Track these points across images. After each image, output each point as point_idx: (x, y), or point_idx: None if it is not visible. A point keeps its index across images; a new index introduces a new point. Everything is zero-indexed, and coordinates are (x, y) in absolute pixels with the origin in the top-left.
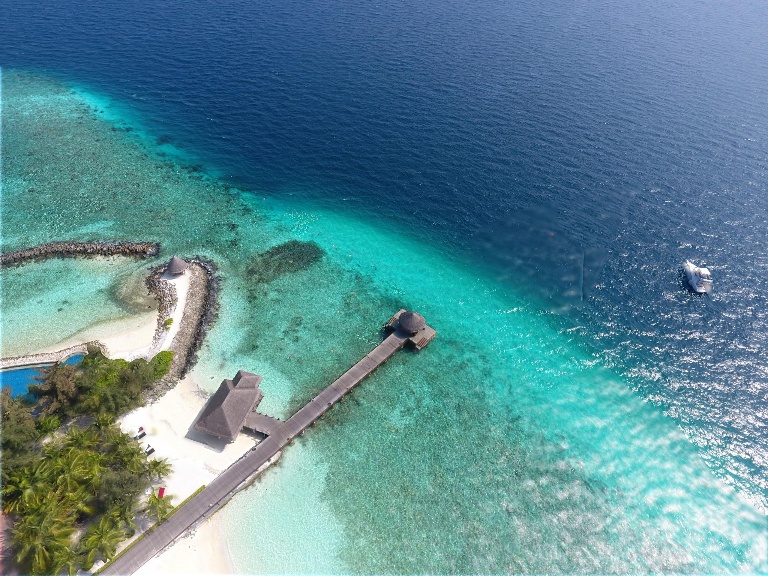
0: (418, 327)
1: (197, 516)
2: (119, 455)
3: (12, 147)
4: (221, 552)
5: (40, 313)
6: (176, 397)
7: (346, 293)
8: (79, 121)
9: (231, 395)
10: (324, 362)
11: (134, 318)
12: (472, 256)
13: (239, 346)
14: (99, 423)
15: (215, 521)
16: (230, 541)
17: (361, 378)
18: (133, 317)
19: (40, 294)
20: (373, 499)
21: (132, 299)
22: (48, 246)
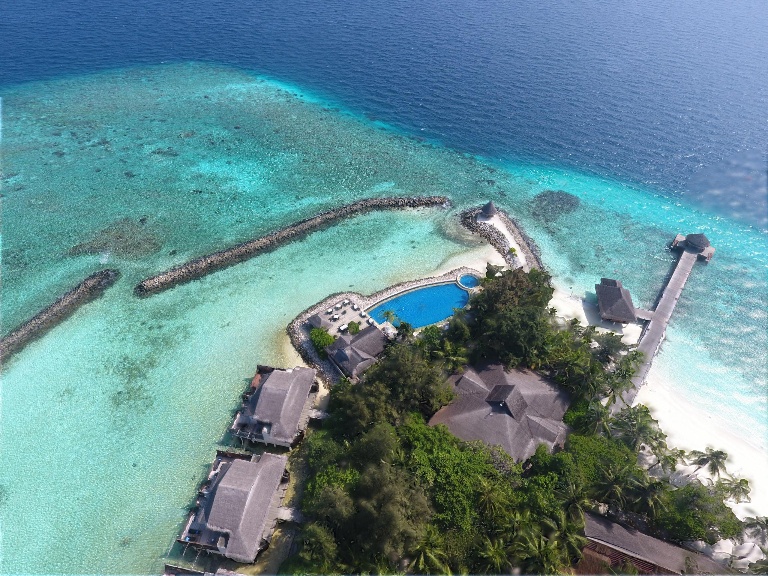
0: (707, 244)
1: (644, 371)
2: (575, 332)
3: (256, 127)
4: (673, 392)
5: (401, 250)
6: (558, 301)
7: (619, 227)
8: (291, 104)
9: (622, 291)
10: (642, 274)
11: (477, 250)
12: (693, 196)
13: (571, 266)
14: (553, 310)
15: (652, 375)
16: (673, 386)
17: (685, 281)
18: (475, 250)
19: (387, 237)
20: (748, 358)
21: (463, 237)
22: (366, 201)
